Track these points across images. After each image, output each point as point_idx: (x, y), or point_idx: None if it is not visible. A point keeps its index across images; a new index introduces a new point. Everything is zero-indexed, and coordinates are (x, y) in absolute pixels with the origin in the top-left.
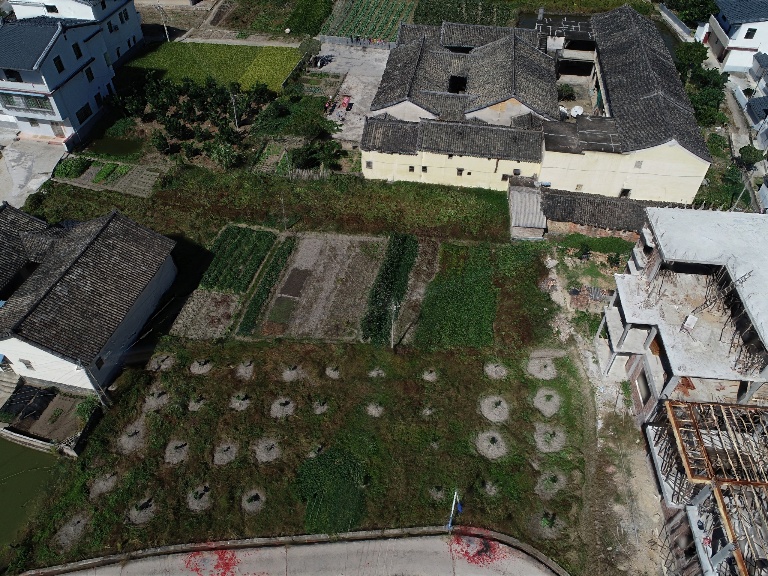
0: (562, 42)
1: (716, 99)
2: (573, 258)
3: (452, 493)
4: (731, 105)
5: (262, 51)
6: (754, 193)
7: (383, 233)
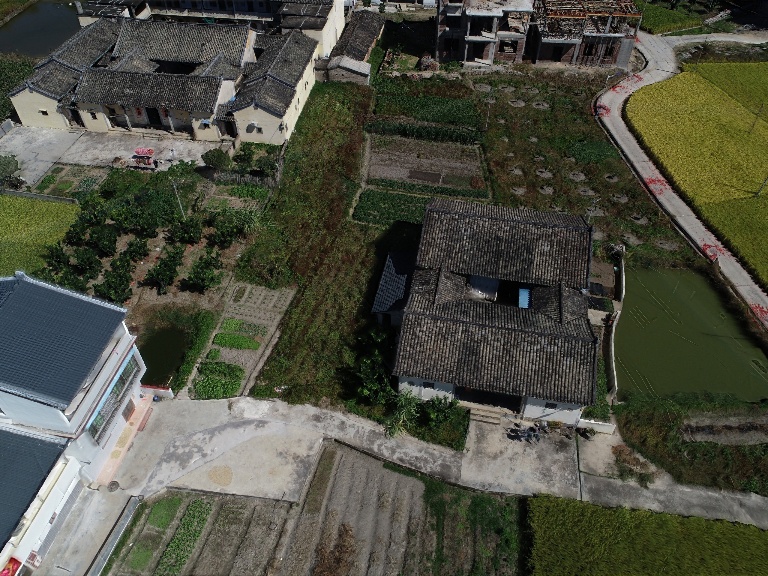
0: (128, 14)
1: None
2: None
3: (576, 116)
4: None
5: None
6: None
7: None
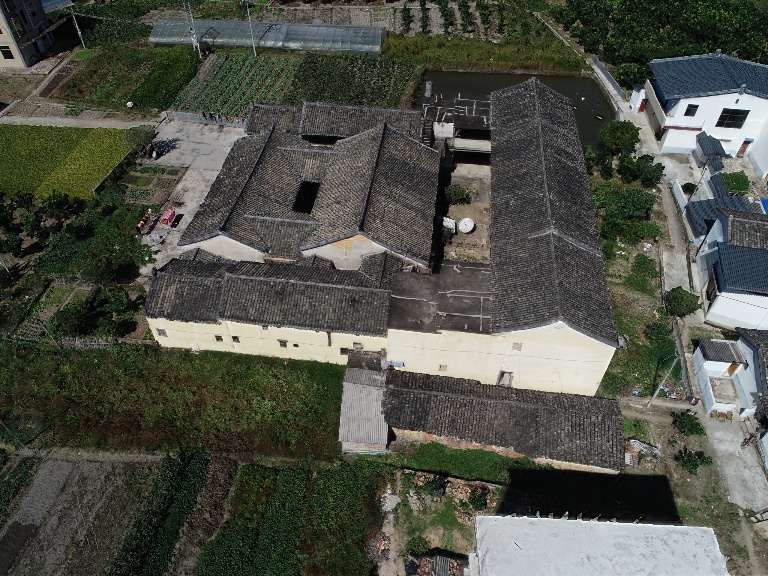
0: (452, 129)
1: (644, 208)
2: (421, 494)
3: None
4: (667, 206)
5: (88, 136)
6: (685, 363)
7: (162, 448)
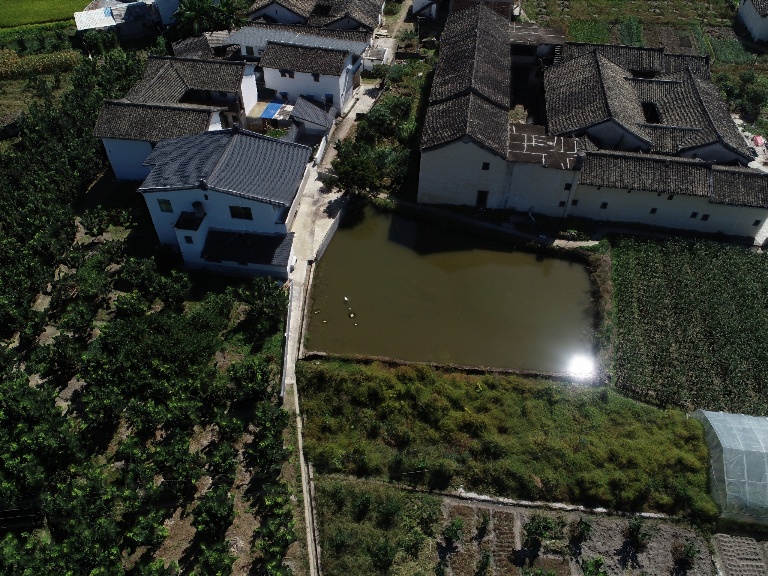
0: None
1: None
2: None
3: None
4: None
5: None
6: None
7: None
